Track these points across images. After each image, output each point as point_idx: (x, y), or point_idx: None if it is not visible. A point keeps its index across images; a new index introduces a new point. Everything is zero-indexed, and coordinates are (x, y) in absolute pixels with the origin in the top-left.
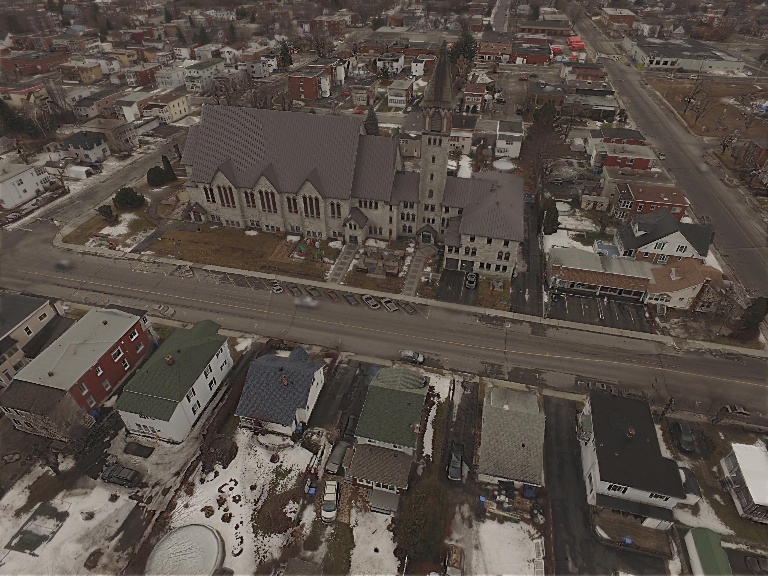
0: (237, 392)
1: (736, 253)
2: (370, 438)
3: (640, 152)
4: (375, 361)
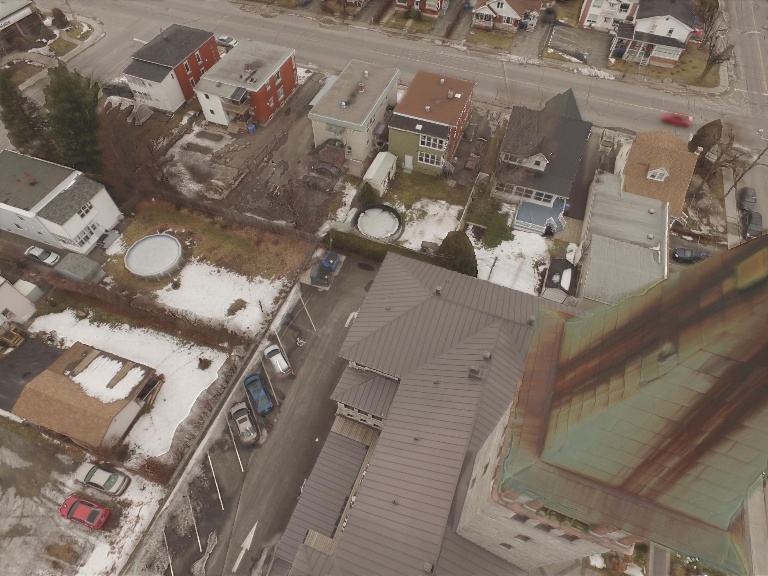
0: None
1: (519, 98)
2: None
3: (262, 55)
4: None
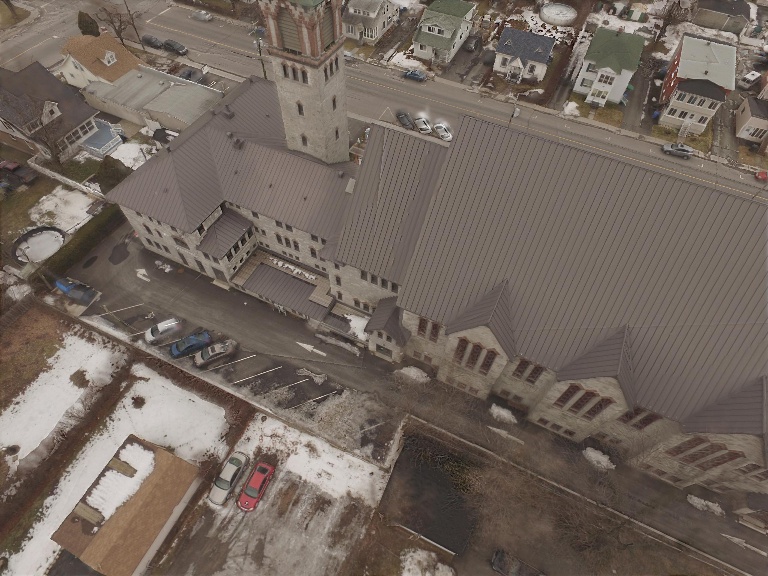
0: (561, 61)
1: None
2: (466, 2)
3: None
4: (449, 82)
